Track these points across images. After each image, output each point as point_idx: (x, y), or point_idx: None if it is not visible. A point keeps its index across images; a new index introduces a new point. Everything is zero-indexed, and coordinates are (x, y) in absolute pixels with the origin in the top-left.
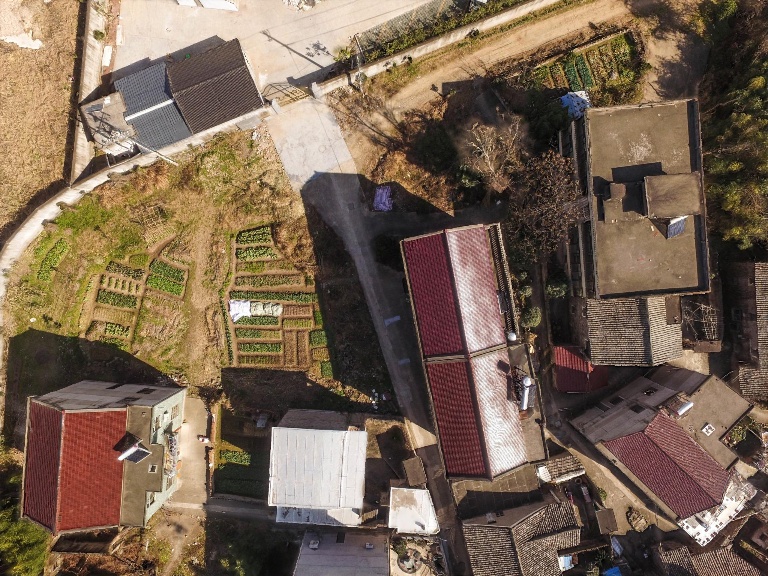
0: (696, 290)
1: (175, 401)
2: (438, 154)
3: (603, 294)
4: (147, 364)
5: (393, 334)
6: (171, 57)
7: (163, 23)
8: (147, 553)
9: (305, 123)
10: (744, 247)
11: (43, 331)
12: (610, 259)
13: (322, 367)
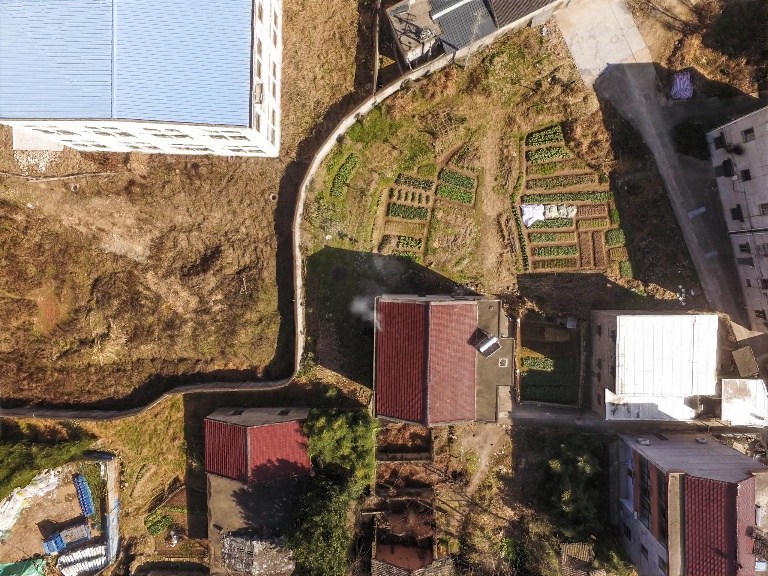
0: None
1: None
2: (736, 34)
3: None
4: (441, 275)
5: (698, 226)
6: None
7: None
8: (455, 463)
9: (596, 13)
10: None
11: (338, 248)
12: None
13: (621, 267)
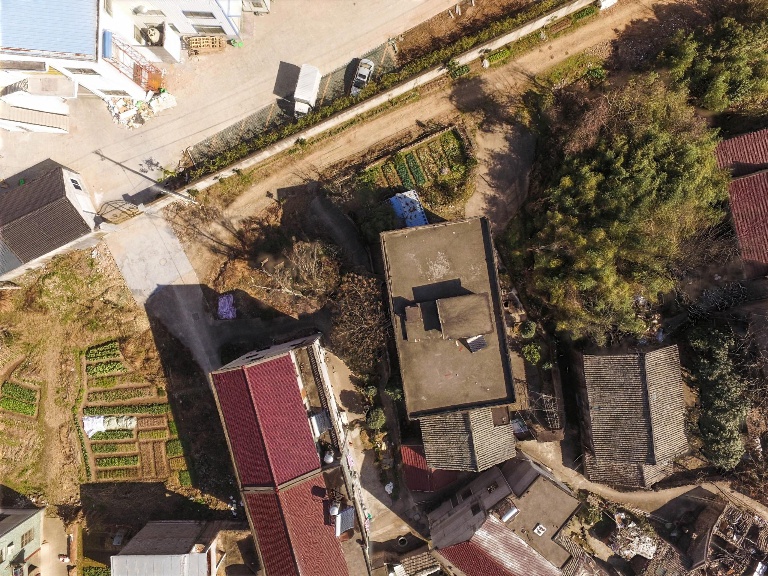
0: (504, 401)
1: (26, 527)
2: (279, 258)
3: (414, 411)
4: (5, 486)
5: None
6: (5, 183)
7: None
8: None
9: (144, 238)
10: (574, 338)
11: None
12: (418, 376)
13: (180, 476)
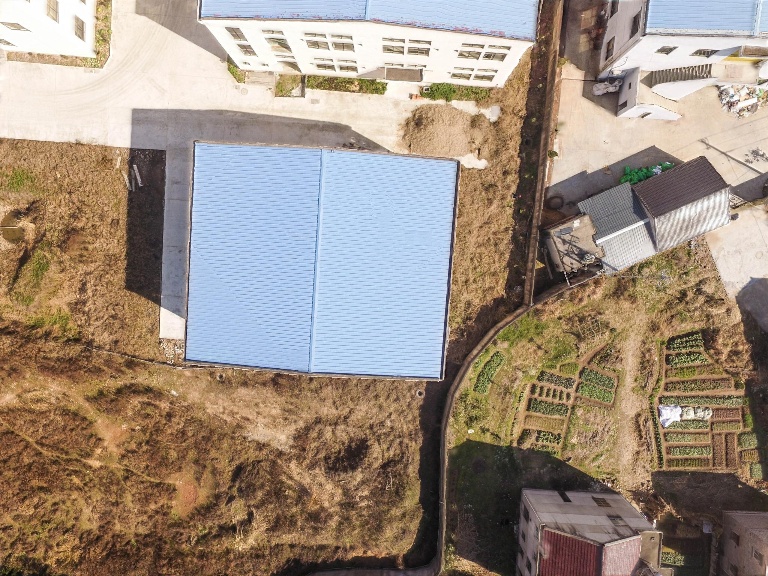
0: None
1: None
2: None
3: None
4: (578, 470)
5: None
6: (609, 169)
7: (601, 135)
8: None
9: (743, 230)
10: None
11: (479, 441)
12: None
13: (752, 469)
